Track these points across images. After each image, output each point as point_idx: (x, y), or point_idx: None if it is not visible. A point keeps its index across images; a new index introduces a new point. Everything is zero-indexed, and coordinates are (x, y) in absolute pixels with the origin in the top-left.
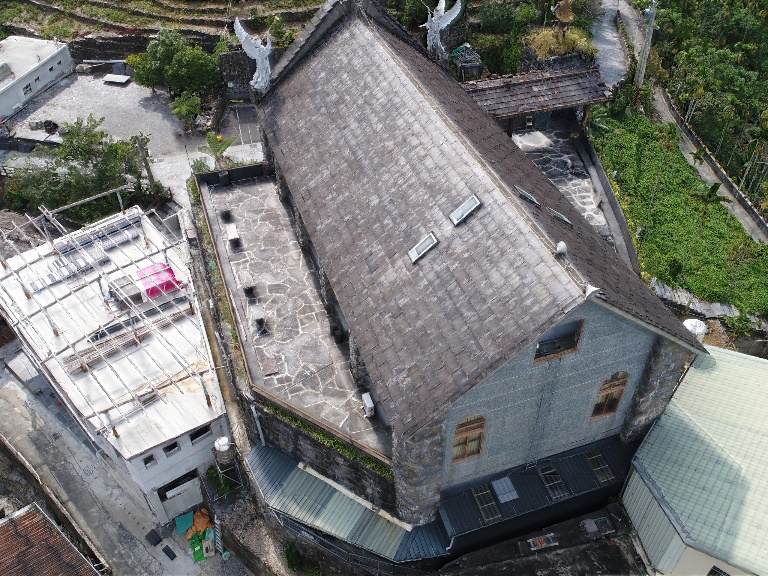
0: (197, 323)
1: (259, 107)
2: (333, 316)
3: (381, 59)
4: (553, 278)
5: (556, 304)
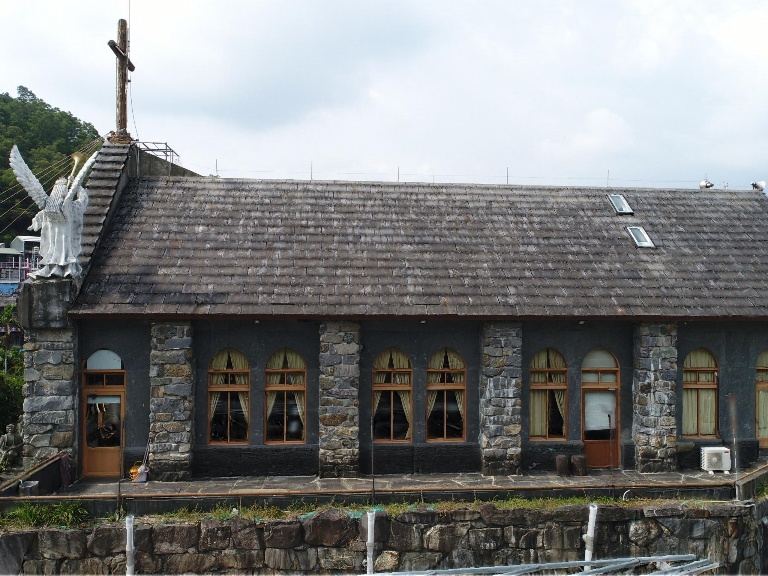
0: (519, 568)
1: (91, 306)
2: (525, 472)
3: (298, 184)
4: (734, 194)
5: (761, 200)
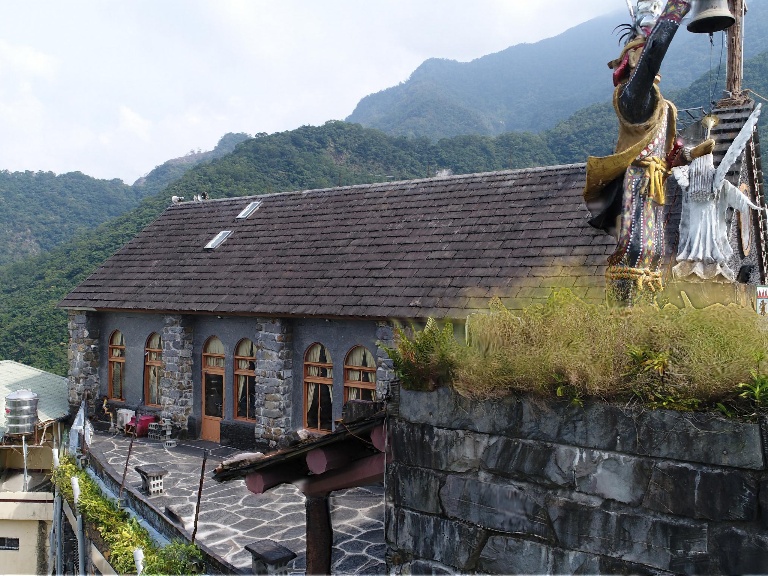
0: None
1: None
2: None
3: None
4: None
5: None
